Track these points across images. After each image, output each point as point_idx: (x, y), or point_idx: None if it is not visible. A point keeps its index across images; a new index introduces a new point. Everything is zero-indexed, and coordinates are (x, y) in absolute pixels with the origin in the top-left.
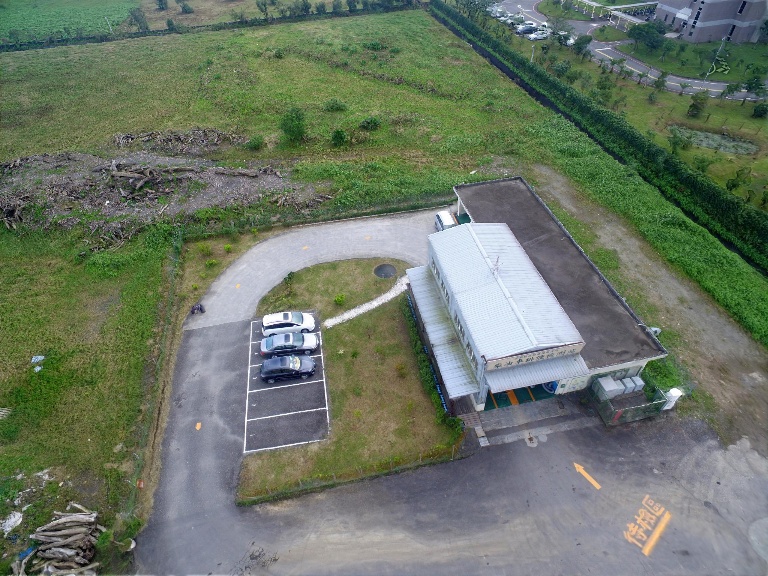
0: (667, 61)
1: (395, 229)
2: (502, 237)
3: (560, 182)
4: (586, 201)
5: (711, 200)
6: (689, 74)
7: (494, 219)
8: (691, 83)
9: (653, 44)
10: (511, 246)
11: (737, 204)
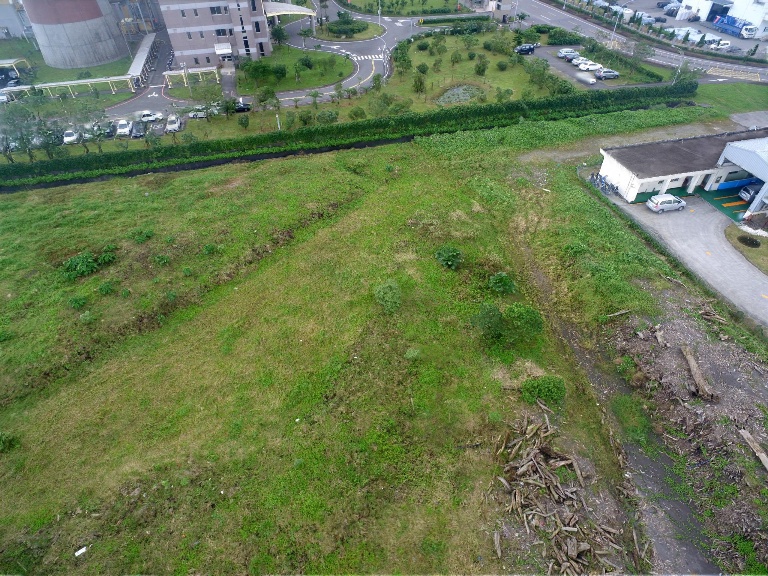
0: (302, 81)
1: (681, 236)
2: (752, 143)
3: (544, 153)
4: (572, 146)
5: (566, 104)
6: (334, 79)
7: (676, 165)
8: (351, 82)
9: (282, 73)
10: (759, 141)
11: (579, 95)
